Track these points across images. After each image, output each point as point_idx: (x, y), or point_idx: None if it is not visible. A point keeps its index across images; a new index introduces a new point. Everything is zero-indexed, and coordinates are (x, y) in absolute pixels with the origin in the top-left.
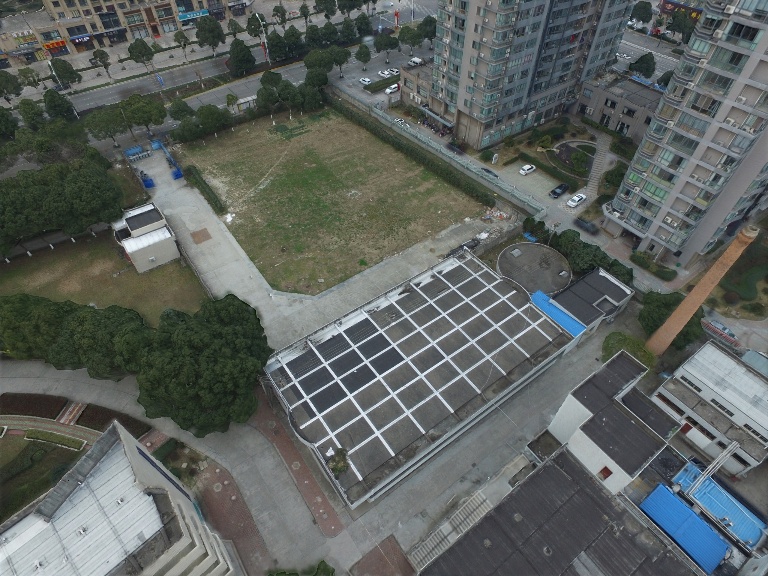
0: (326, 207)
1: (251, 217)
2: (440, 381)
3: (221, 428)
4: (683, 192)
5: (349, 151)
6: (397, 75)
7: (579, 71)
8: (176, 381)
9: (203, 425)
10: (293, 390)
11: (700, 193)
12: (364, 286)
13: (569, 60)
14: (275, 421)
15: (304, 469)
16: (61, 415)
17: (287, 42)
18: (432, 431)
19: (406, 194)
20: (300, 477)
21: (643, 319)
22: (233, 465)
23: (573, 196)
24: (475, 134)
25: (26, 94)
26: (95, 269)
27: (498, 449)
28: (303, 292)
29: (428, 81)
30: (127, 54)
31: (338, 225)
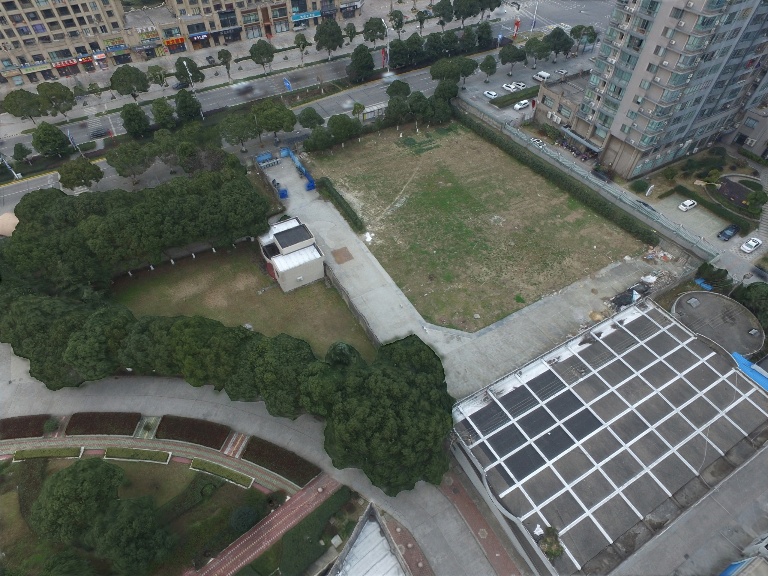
0: (470, 232)
1: (391, 238)
2: (649, 455)
3: (410, 486)
4: None
5: (485, 171)
6: (524, 90)
7: (744, 98)
8: (379, 436)
9: (398, 484)
10: (483, 449)
11: None
12: (525, 327)
13: (739, 86)
14: (452, 477)
15: (493, 539)
16: (224, 445)
17: (409, 49)
18: (650, 516)
19: (554, 224)
20: (490, 548)
21: None
22: (414, 525)
23: (745, 240)
24: (627, 162)
25: (149, 91)
26: (239, 284)
27: (712, 540)
28: (459, 328)
29: (573, 100)
30: (242, 54)
31: (486, 254)
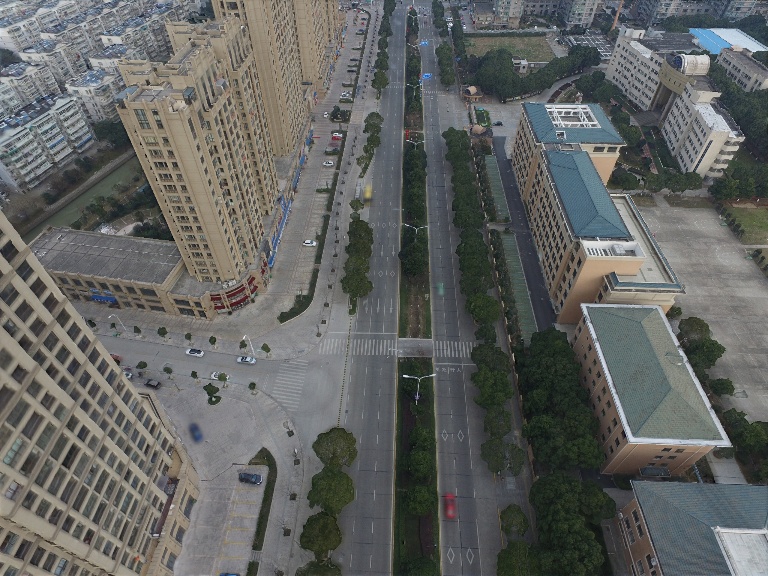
0: (521, 50)
1: None
2: None
3: None
4: (588, 6)
5: None
6: None
7: None
8: None
9: None
10: None
11: (592, 4)
12: None
13: None
14: None
15: None
16: None
17: None
18: None
19: None
20: None
21: (606, 30)
22: None
23: None
24: (516, 23)
25: None
26: None
27: None
28: None
29: (489, 14)
30: None
31: None
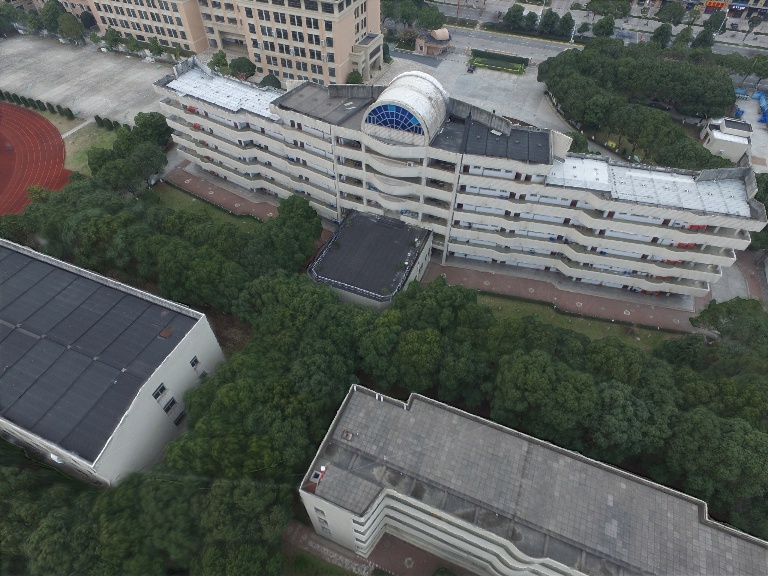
0: None
1: None
2: None
3: None
4: None
5: None
6: None
7: None
8: None
9: None
10: None
11: None
12: None
13: None
14: (755, 272)
15: (760, 303)
16: None
17: None
18: None
19: None
20: None
21: None
22: None
23: None
24: None
25: (673, 29)
26: None
27: None
28: None
29: None
30: (764, 31)
31: None
